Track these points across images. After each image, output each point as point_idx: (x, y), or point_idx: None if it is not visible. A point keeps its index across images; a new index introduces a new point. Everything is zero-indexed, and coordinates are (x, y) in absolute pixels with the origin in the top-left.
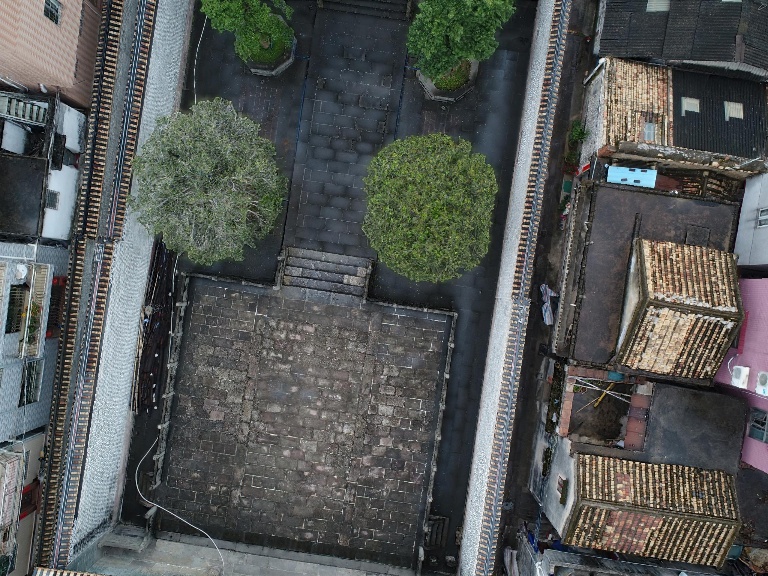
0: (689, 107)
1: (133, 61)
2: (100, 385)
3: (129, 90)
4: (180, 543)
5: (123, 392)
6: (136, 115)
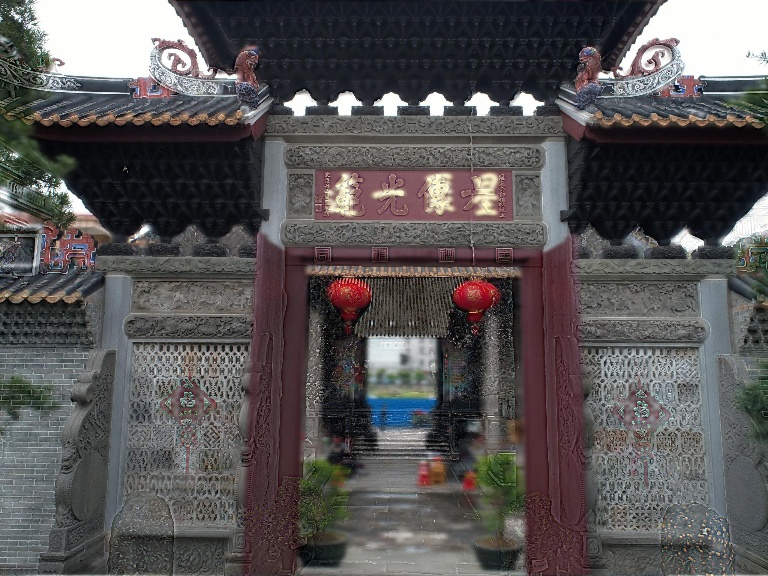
0: None
1: None
2: None
3: None
4: (477, 412)
5: None
6: None
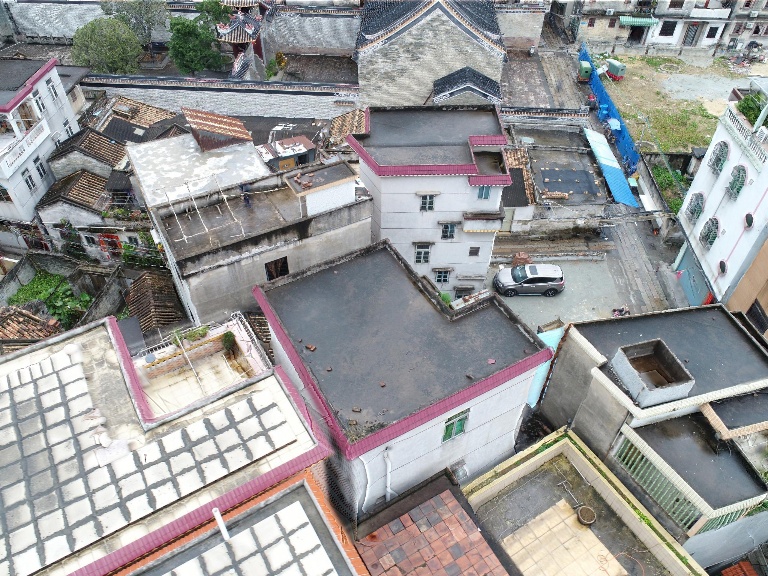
0: (138, 131)
1: (195, 2)
2: (70, 7)
3: (183, 2)
4: None
5: (72, 30)
6: (176, 7)
